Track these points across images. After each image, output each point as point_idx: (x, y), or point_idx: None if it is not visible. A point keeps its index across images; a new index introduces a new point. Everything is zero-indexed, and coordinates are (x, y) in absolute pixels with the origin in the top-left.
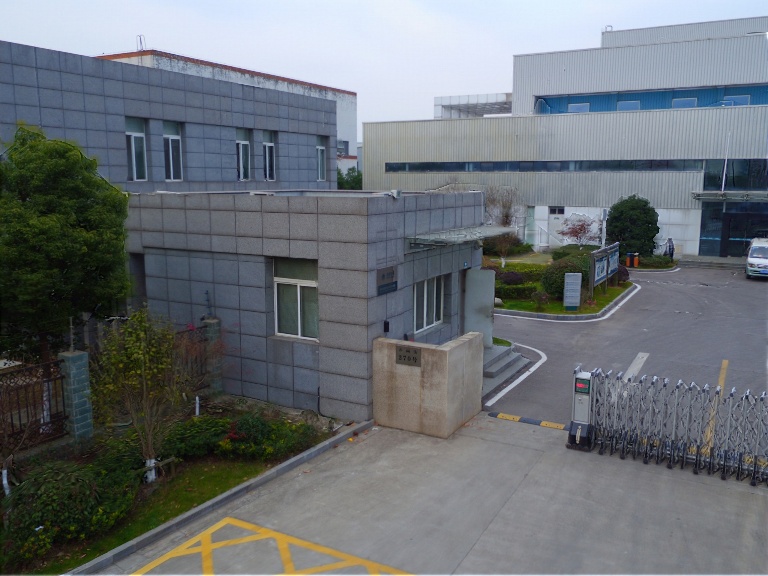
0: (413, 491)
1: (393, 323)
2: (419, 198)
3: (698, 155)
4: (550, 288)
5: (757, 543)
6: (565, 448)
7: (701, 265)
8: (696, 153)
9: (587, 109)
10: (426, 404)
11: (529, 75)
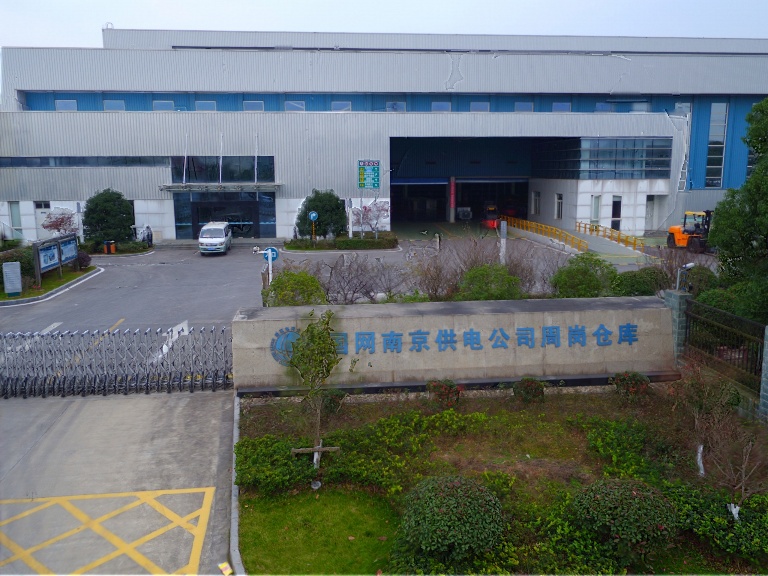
0: None
1: None
2: None
3: (164, 153)
4: None
5: (37, 430)
6: None
7: (173, 247)
8: (162, 151)
9: (75, 106)
10: None
11: (7, 68)
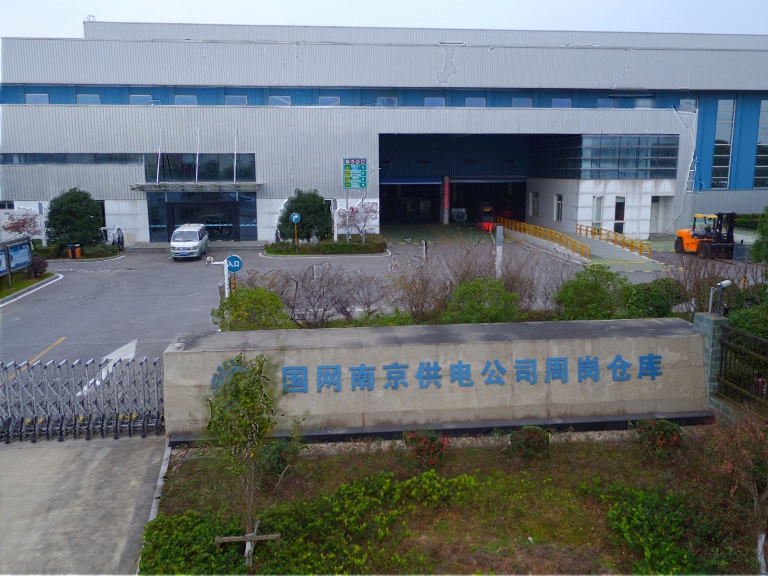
0: None
1: None
2: None
3: (137, 149)
4: None
5: None
6: None
7: (145, 251)
8: (135, 147)
9: (46, 100)
10: None
11: None
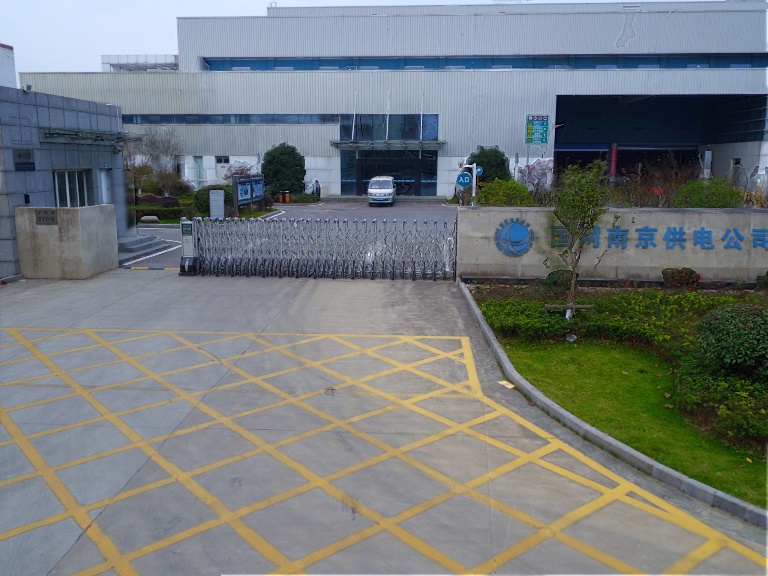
0: (50, 301)
1: (34, 198)
2: (51, 97)
3: (334, 111)
4: (201, 207)
5: (285, 296)
6: (178, 276)
7: (340, 200)
8: (332, 109)
9: None
10: (65, 254)
11: (193, 37)
